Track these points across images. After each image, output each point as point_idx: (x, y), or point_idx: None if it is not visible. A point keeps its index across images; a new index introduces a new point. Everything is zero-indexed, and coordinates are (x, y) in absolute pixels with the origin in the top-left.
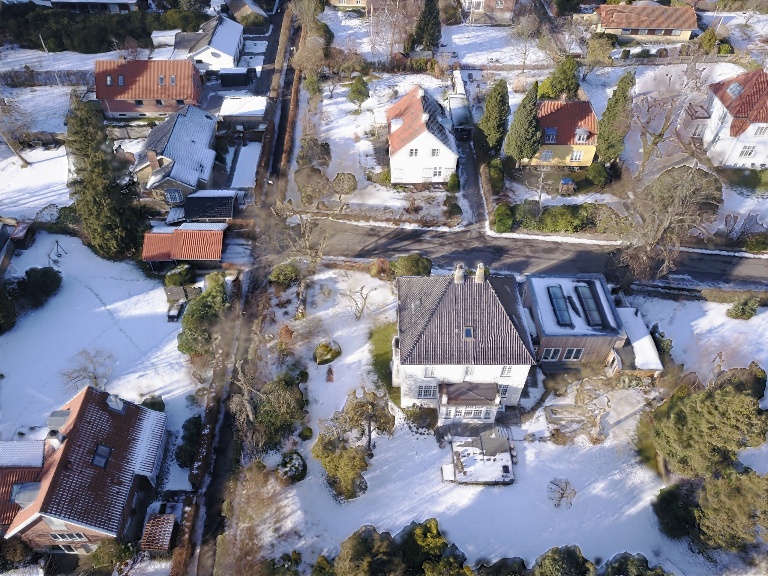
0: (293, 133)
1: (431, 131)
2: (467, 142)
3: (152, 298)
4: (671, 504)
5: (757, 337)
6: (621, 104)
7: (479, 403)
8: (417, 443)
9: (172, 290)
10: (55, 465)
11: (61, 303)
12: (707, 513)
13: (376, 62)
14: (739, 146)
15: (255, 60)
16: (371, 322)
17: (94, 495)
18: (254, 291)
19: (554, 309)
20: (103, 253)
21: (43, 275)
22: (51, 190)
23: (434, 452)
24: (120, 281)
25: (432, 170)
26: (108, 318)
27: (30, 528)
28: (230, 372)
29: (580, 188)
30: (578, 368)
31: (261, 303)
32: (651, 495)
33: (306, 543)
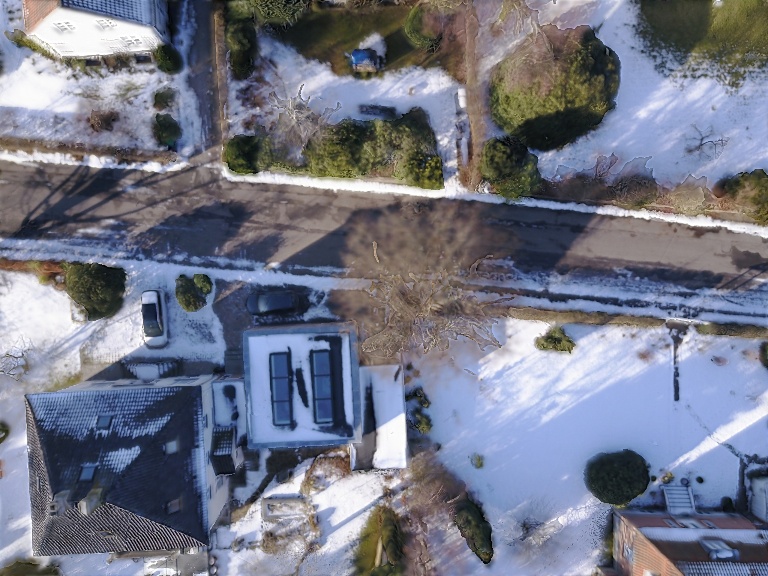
0: None
1: None
2: None
3: None
4: None
5: (559, 382)
6: None
7: (156, 555)
8: None
9: None
10: None
11: None
12: None
13: None
14: None
15: None
16: (45, 374)
17: None
18: None
19: (271, 398)
20: None
21: None
22: None
23: (126, 567)
24: None
25: (119, 39)
26: None
27: None
28: None
29: (392, 53)
30: None
31: None
32: None
33: None
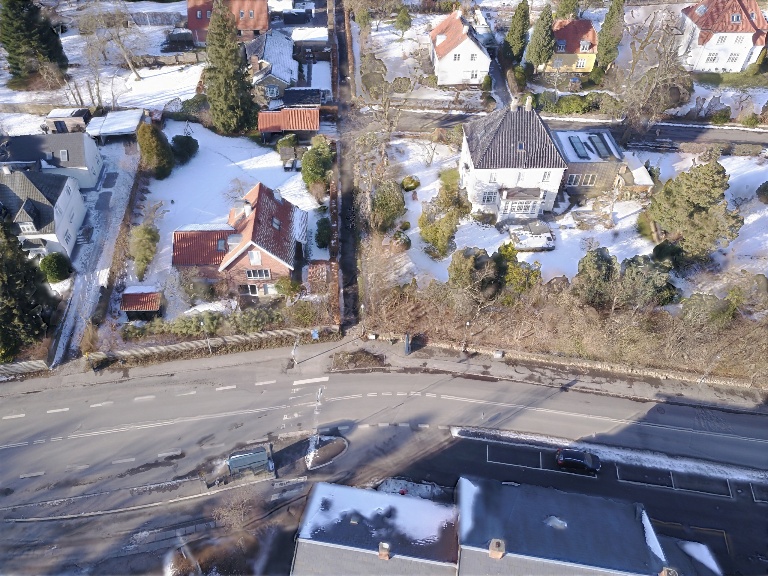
0: (353, 53)
1: (471, 39)
2: (493, 59)
3: (269, 158)
4: (663, 249)
5: None
6: (616, 16)
7: (528, 198)
8: (484, 231)
9: (285, 150)
10: (252, 221)
11: (200, 162)
12: (687, 239)
13: (410, 5)
14: (705, 53)
15: (307, 6)
16: (438, 168)
17: (277, 243)
18: (345, 154)
19: (575, 148)
20: (223, 131)
21: (187, 139)
22: (166, 94)
23: (497, 236)
24: (241, 149)
25: (470, 73)
26: (239, 170)
27: (236, 263)
28: (340, 198)
29: (584, 87)
30: (593, 191)
31: (353, 159)
32: (649, 252)
33: (419, 278)
